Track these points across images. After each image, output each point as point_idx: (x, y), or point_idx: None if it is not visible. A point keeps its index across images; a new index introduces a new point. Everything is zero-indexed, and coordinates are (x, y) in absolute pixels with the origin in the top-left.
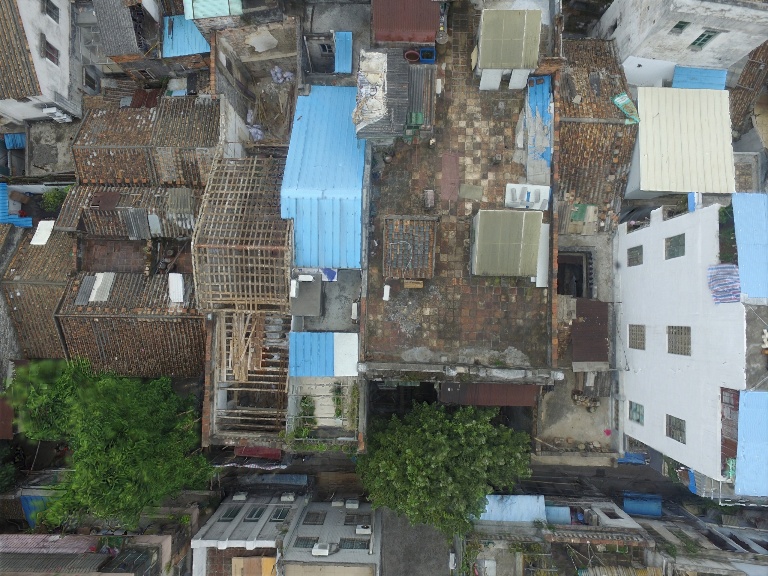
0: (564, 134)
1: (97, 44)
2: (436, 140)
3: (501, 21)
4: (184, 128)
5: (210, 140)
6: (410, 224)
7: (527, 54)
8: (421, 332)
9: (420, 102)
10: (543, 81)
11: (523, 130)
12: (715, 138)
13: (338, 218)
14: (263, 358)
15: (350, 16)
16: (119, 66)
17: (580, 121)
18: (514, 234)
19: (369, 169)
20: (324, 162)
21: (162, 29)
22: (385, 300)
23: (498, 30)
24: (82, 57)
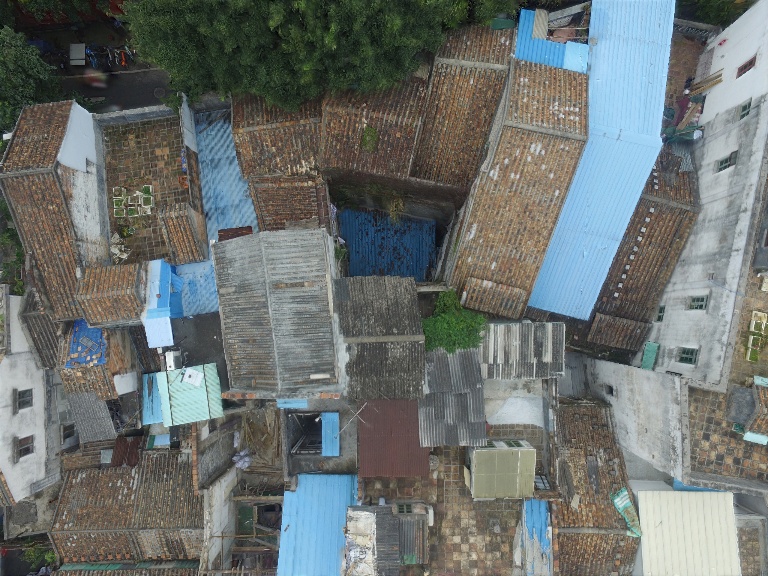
0: (563, 541)
1: None
2: (430, 559)
3: (494, 459)
4: (167, 498)
5: (195, 517)
6: None
7: (522, 486)
8: None
9: (412, 547)
10: None
11: (521, 547)
12: (721, 550)
13: None
14: None
15: None
16: None
17: (580, 532)
18: None
19: None
20: None
21: (141, 391)
22: None
23: (491, 467)
24: (59, 415)
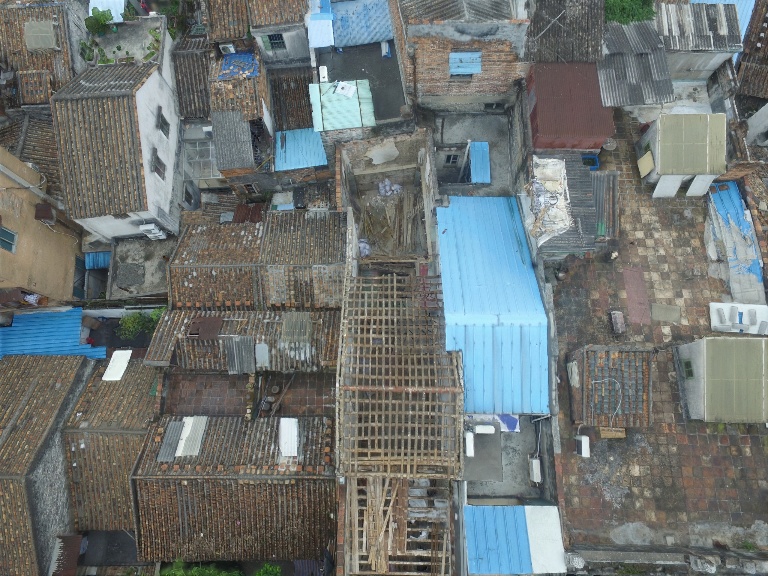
0: None
1: (202, 159)
2: None
3: (680, 125)
4: (296, 244)
5: (328, 256)
6: (618, 356)
7: (712, 159)
8: (632, 500)
9: (601, 211)
10: (727, 187)
11: (714, 240)
12: None
13: (518, 349)
14: (408, 536)
15: (483, 127)
16: (218, 181)
17: None
18: (752, 367)
19: (551, 288)
20: (488, 280)
21: (274, 143)
22: (582, 456)
23: (678, 135)
24: (184, 172)
